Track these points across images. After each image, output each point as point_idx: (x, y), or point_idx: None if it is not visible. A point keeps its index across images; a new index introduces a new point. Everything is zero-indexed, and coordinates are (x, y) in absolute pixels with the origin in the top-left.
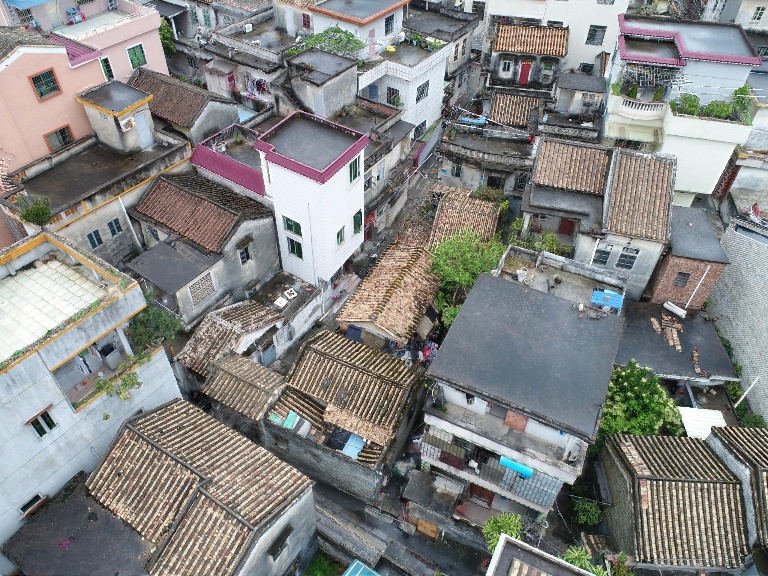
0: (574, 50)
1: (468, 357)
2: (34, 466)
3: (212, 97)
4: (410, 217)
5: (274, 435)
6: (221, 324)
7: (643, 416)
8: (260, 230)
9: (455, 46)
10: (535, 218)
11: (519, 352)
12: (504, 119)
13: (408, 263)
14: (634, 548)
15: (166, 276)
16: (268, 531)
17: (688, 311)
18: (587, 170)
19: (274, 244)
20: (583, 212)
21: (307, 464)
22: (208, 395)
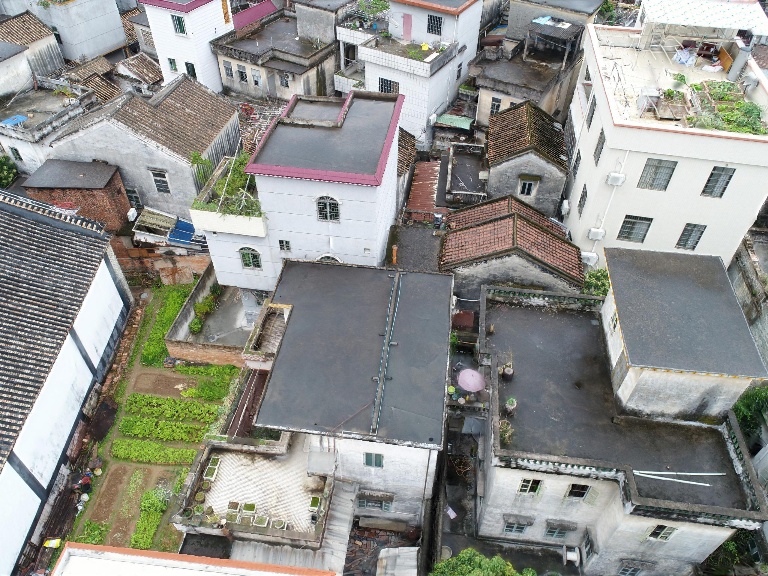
0: None
1: None
2: (21, 2)
3: None
4: None
5: None
6: None
7: None
8: None
9: (493, 98)
10: None
11: None
12: None
13: None
14: None
15: (141, 16)
16: None
17: None
18: None
19: None
20: None
21: None
22: None
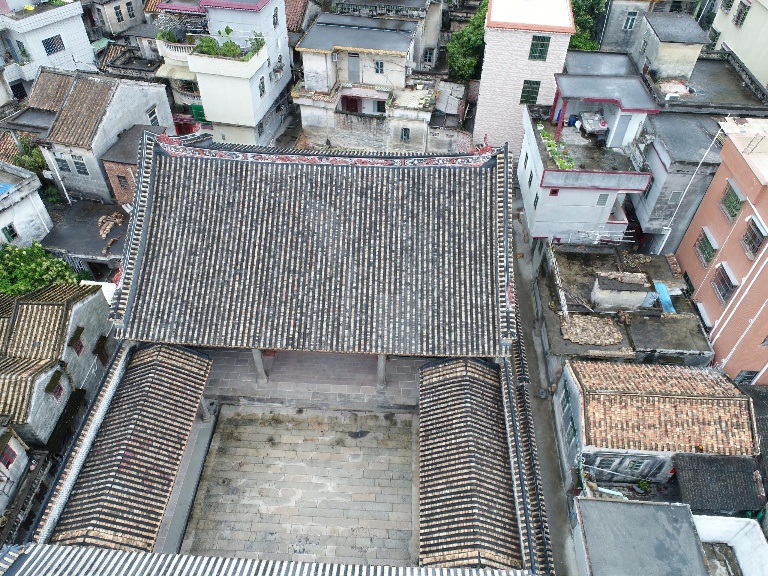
0: None
1: None
2: None
3: None
4: None
5: None
6: None
7: (22, 281)
8: None
9: (114, 8)
10: None
11: None
12: None
13: None
14: None
15: None
16: None
17: None
18: None
19: None
20: (44, 127)
21: None
22: None
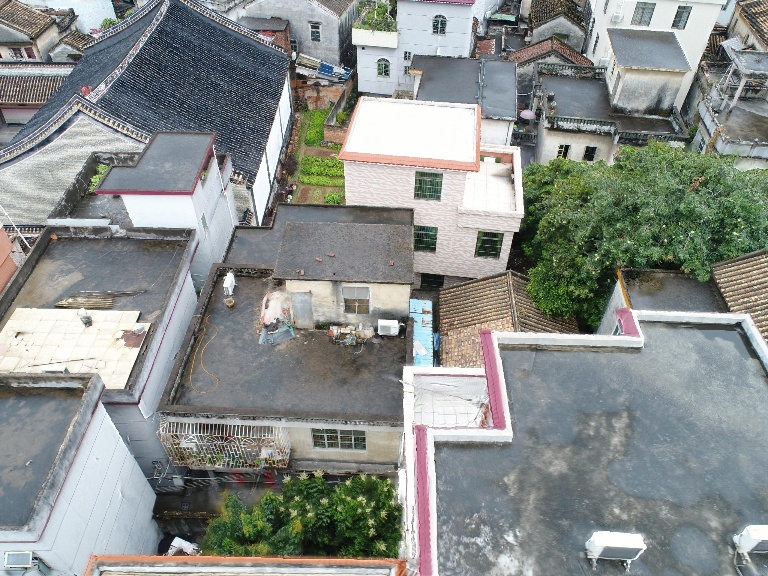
0: None
1: None
2: None
3: None
4: None
5: None
6: None
7: None
8: None
9: None
10: None
11: None
12: None
13: None
14: None
15: None
16: None
17: None
18: None
19: None
20: None
21: None
22: None
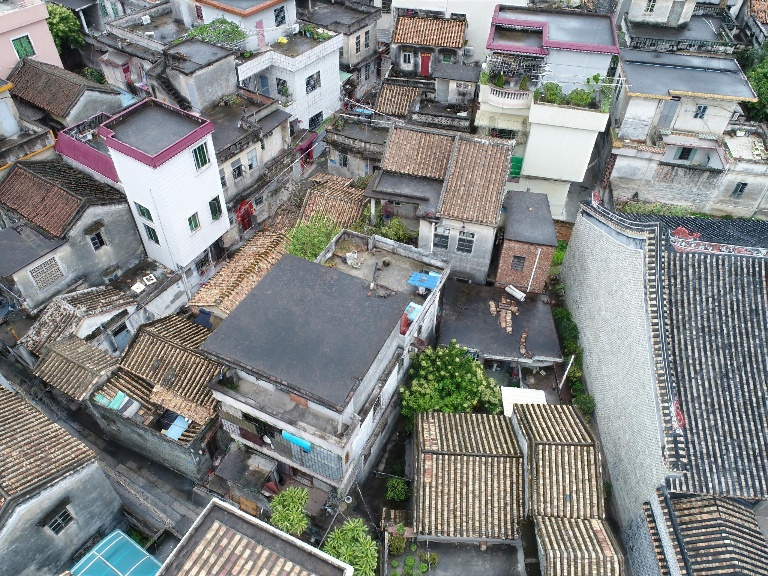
0: (479, 42)
1: (244, 333)
2: None
3: (89, 87)
4: (281, 205)
5: (102, 415)
6: (65, 308)
7: (456, 395)
8: (113, 216)
9: (355, 38)
10: (390, 204)
11: (296, 328)
12: (390, 109)
13: (266, 249)
14: (413, 520)
15: (4, 260)
16: (31, 502)
17: (529, 294)
18: (433, 156)
19: (134, 230)
20: (422, 197)
21: (138, 444)
22: (38, 376)
